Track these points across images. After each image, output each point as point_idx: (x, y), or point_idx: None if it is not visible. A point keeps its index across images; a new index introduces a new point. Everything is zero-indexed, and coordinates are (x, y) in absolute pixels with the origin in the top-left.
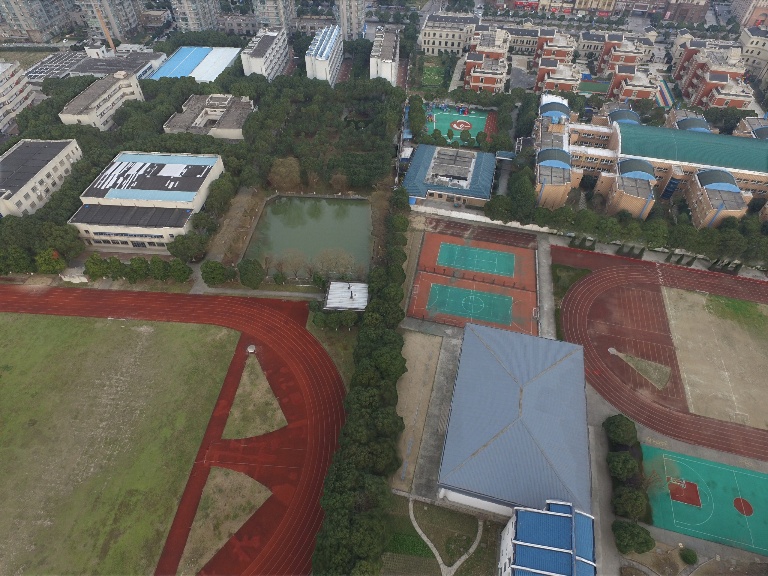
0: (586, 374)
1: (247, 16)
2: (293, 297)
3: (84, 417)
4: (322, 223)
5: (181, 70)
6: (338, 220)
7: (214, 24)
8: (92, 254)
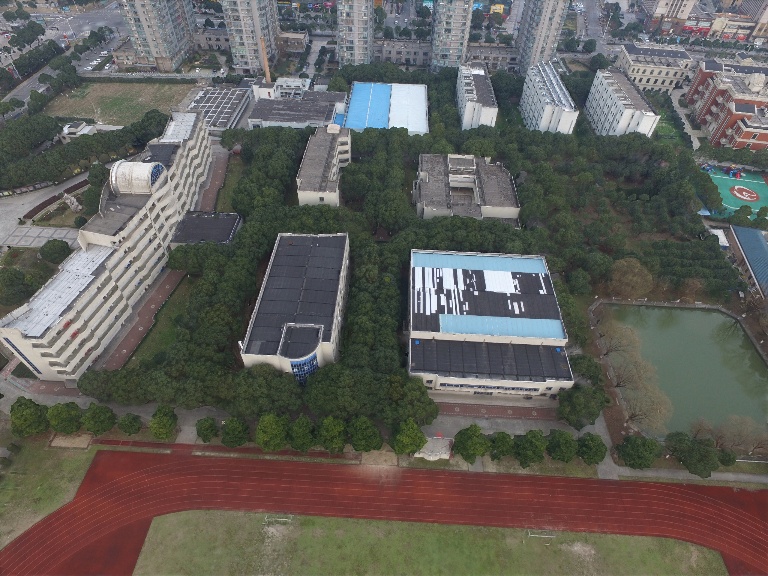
0: None
1: (404, 42)
2: (744, 483)
3: None
4: (644, 334)
5: (376, 116)
6: (661, 329)
7: (372, 52)
8: (473, 428)
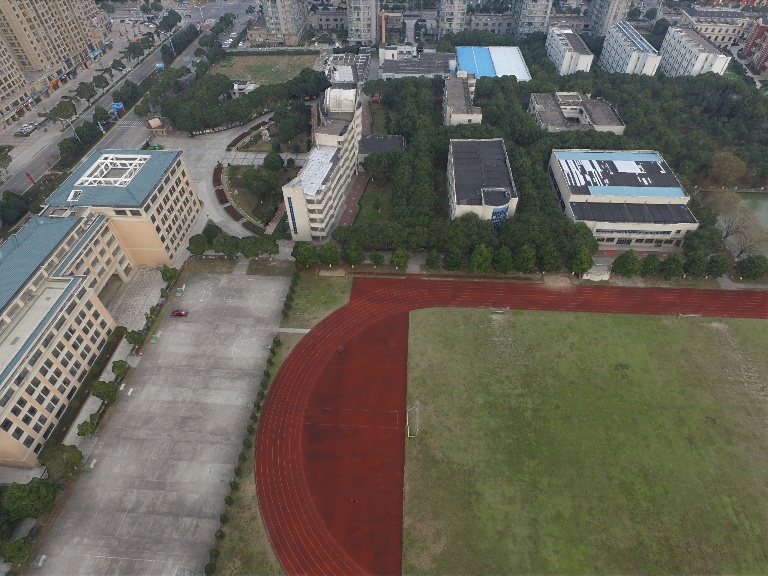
0: None
1: (488, 16)
2: None
3: (758, 414)
4: (734, 218)
5: (484, 69)
6: None
7: None
8: (630, 251)
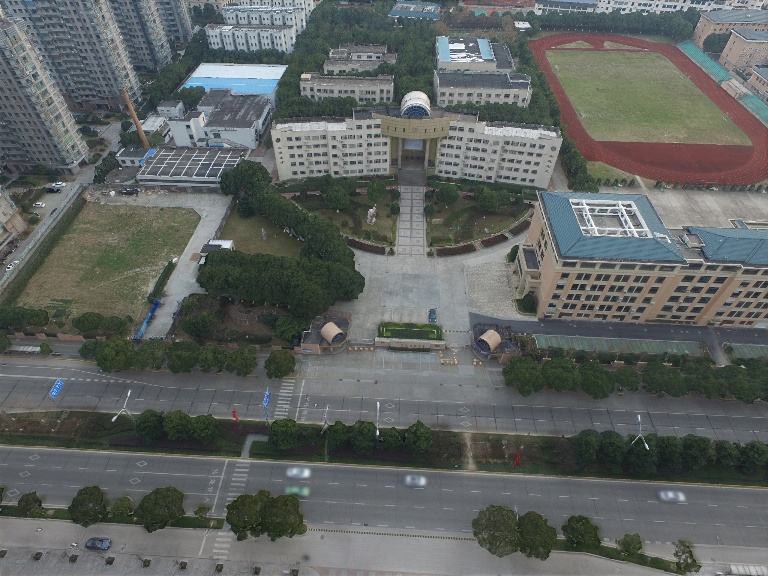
0: None
1: None
2: None
3: None
4: None
5: (253, 82)
6: None
7: None
8: None
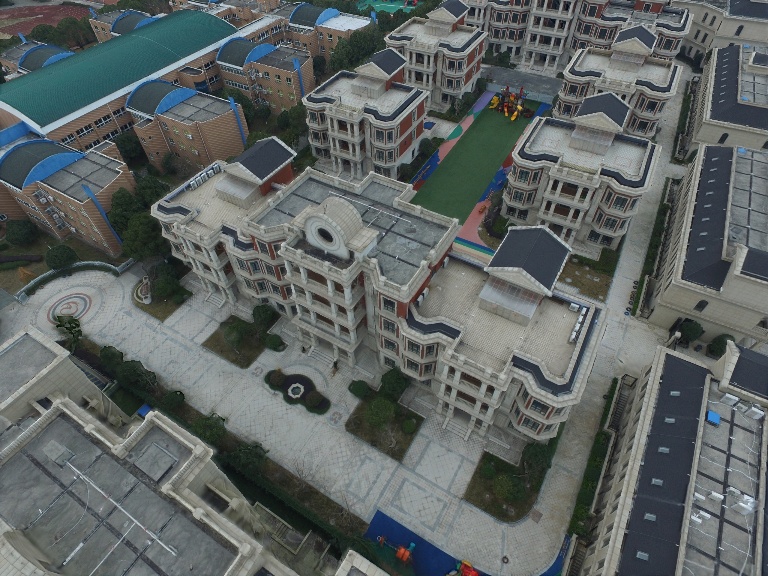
0: (43, 6)
1: None
2: None
3: None
4: None
5: None
6: None
7: None
8: None
